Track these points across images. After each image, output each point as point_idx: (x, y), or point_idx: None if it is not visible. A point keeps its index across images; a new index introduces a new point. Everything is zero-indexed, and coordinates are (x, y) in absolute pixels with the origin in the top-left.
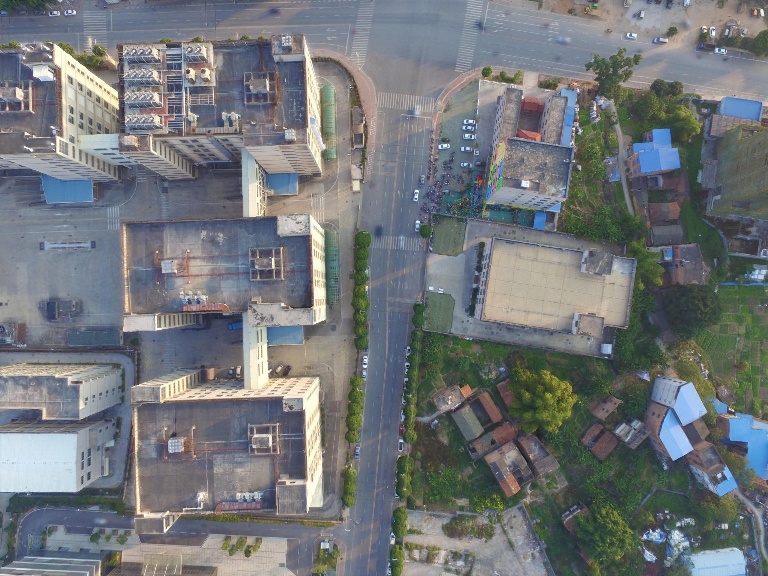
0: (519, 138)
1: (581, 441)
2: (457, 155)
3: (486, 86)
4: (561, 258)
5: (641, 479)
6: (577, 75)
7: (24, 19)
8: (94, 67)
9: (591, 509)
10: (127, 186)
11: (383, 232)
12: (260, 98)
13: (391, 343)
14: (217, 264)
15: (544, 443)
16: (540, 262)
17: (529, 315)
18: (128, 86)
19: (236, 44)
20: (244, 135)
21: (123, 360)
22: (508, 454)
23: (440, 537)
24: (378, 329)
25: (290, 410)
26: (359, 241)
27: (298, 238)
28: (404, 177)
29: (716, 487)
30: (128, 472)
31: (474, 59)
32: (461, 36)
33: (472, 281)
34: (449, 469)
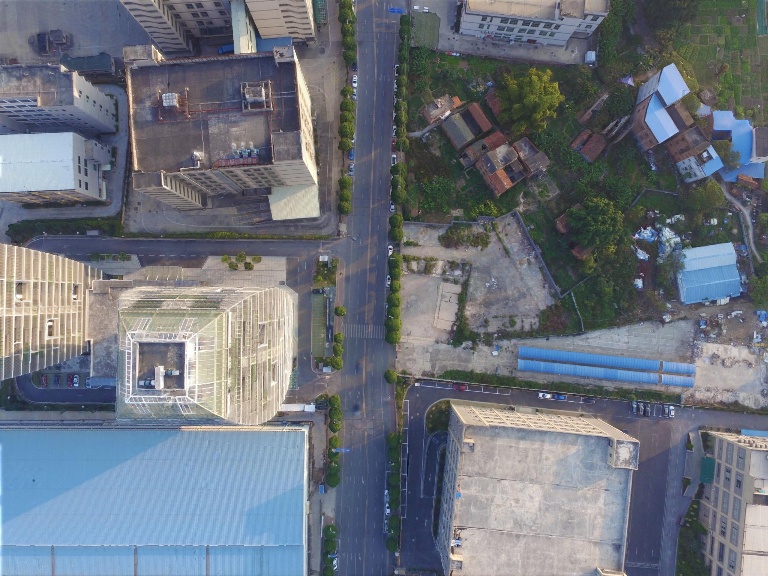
0: None
1: (570, 146)
2: None
3: None
4: None
5: (630, 182)
6: None
7: None
8: None
9: (583, 204)
10: None
11: None
12: None
13: (379, 63)
14: None
15: None
16: None
17: (512, 5)
18: None
19: None
20: None
21: (115, 91)
22: (499, 149)
23: (437, 248)
24: (366, 50)
25: (281, 57)
26: None
27: None
28: None
29: (703, 166)
30: (125, 198)
31: None
32: None
33: None
34: (442, 178)
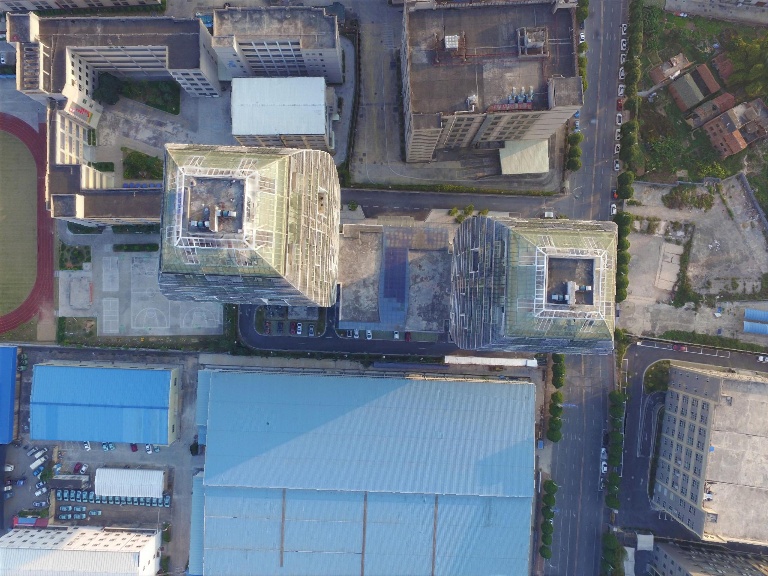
0: None
1: None
2: None
3: None
4: None
5: None
6: None
7: None
8: None
9: None
10: None
11: None
12: None
13: (606, 22)
14: None
15: None
16: None
17: None
18: None
19: None
20: None
21: (342, 42)
22: (736, 109)
23: (660, 208)
24: (593, 8)
25: (566, 2)
26: None
27: None
28: None
29: None
30: (352, 148)
31: None
32: None
33: None
34: (670, 138)
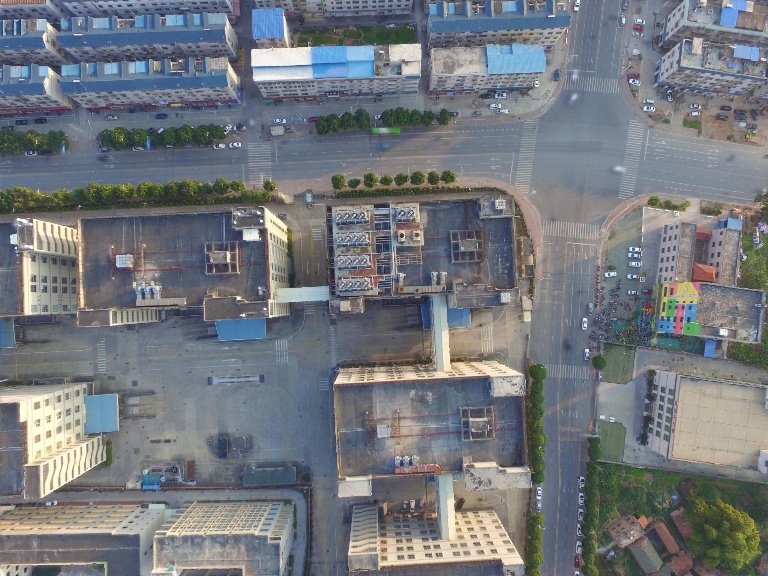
0: (711, 283)
1: (757, 570)
2: (623, 282)
3: (650, 213)
4: (745, 395)
5: None
6: (737, 200)
7: (188, 151)
8: (264, 202)
9: None
10: (295, 319)
11: (552, 361)
12: (466, 255)
13: (564, 473)
14: (427, 424)
15: (720, 572)
16: (724, 399)
17: (715, 453)
18: (337, 247)
19: (441, 202)
20: (457, 297)
21: (294, 495)
22: None
23: None
24: (550, 459)
25: None
26: (537, 376)
27: (507, 396)
28: (571, 305)
29: None
30: None
31: (636, 186)
32: (623, 163)
33: (642, 409)
34: None
